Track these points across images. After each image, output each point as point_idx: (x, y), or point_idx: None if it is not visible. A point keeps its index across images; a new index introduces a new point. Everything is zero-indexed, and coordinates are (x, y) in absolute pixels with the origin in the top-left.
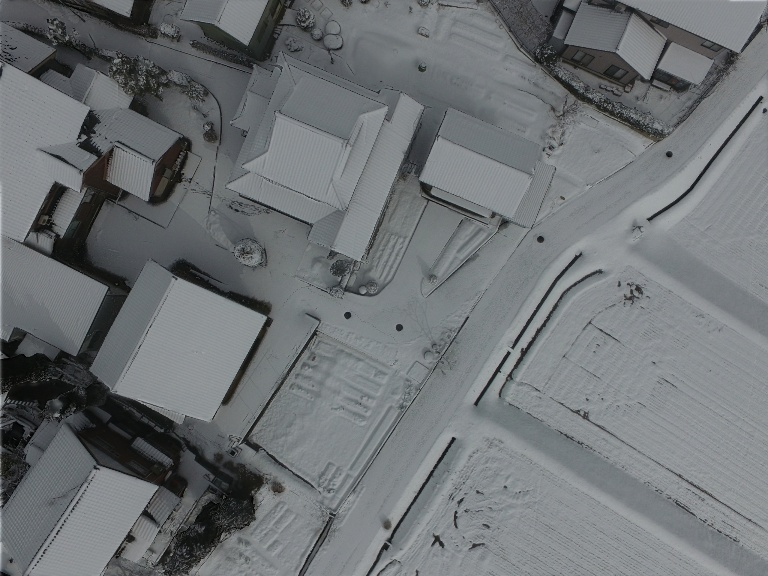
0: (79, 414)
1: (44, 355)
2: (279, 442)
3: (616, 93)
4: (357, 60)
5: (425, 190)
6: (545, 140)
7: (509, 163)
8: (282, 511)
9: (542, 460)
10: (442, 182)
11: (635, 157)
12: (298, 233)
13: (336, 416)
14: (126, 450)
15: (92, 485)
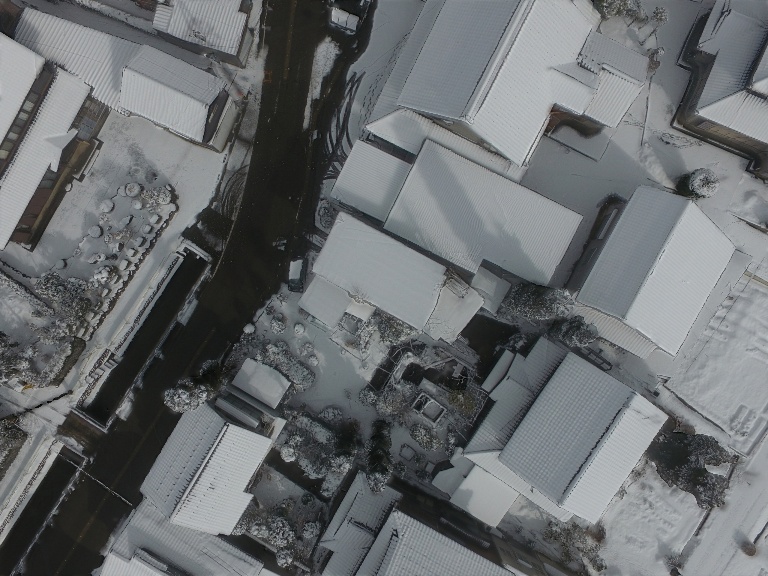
0: (555, 347)
1: None
2: (690, 384)
3: None
4: None
5: None
6: None
7: None
8: None
9: None
10: None
11: None
12: (731, 166)
13: (750, 357)
14: None
15: (628, 412)
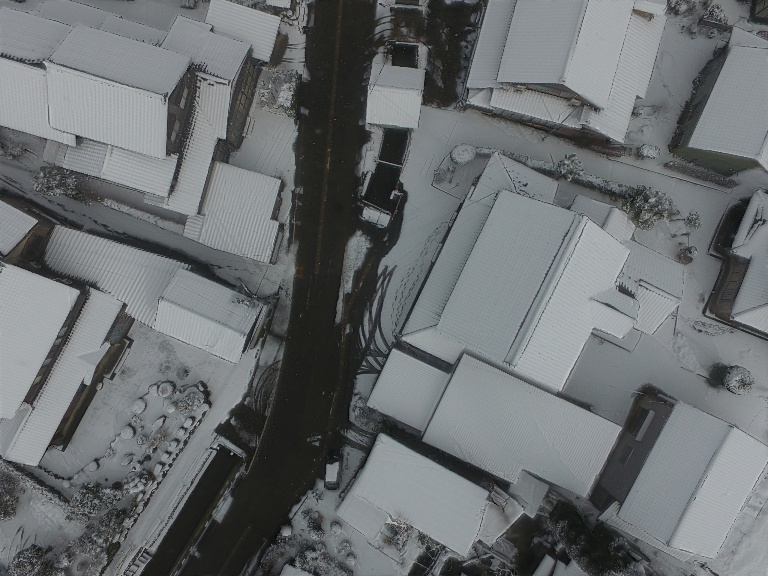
0: None
1: None
2: None
3: None
4: None
5: None
6: None
7: None
8: None
9: None
10: None
11: None
12: (763, 352)
13: None
14: None
15: None
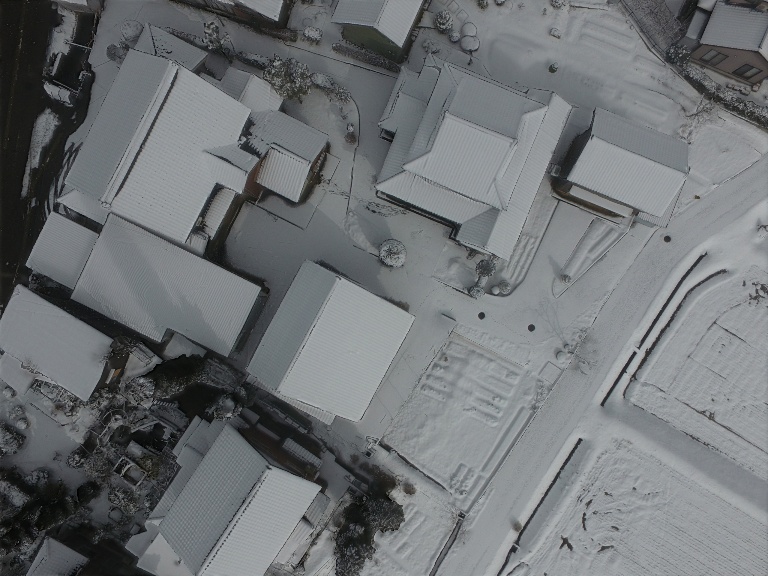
0: None
1: (200, 356)
2: (411, 443)
3: (744, 92)
4: (493, 61)
5: (556, 190)
6: None
7: (663, 162)
8: (412, 513)
9: (672, 461)
10: (591, 181)
11: (761, 156)
12: (435, 234)
13: (468, 417)
14: (279, 451)
15: (264, 485)
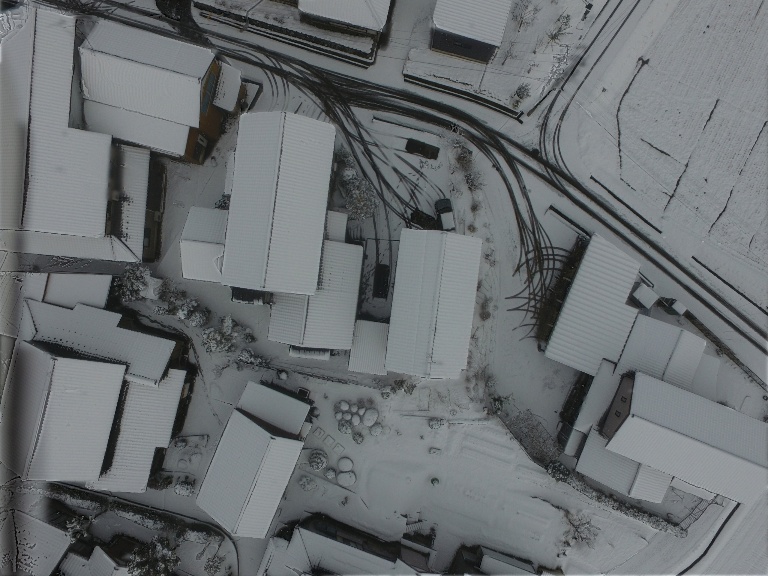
0: None
1: None
2: None
3: None
4: (370, 492)
5: None
6: (559, 548)
7: None
8: None
9: None
10: None
11: None
12: None
13: None
14: None
15: None
